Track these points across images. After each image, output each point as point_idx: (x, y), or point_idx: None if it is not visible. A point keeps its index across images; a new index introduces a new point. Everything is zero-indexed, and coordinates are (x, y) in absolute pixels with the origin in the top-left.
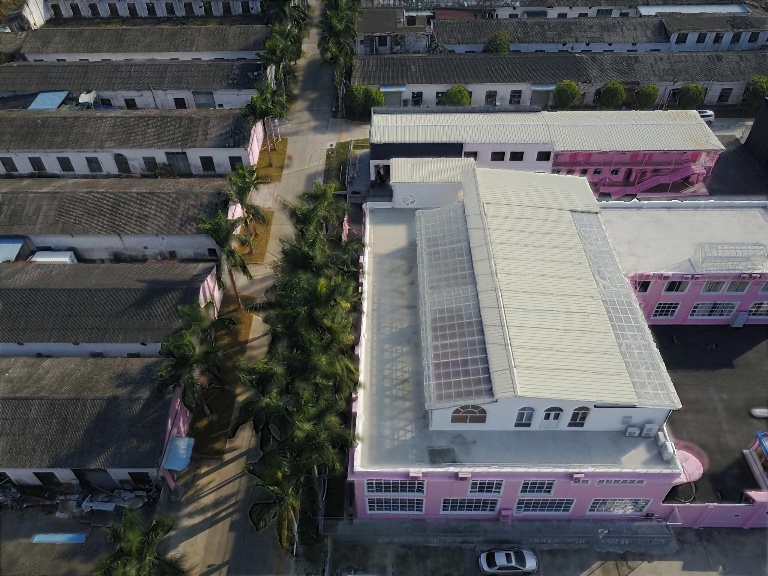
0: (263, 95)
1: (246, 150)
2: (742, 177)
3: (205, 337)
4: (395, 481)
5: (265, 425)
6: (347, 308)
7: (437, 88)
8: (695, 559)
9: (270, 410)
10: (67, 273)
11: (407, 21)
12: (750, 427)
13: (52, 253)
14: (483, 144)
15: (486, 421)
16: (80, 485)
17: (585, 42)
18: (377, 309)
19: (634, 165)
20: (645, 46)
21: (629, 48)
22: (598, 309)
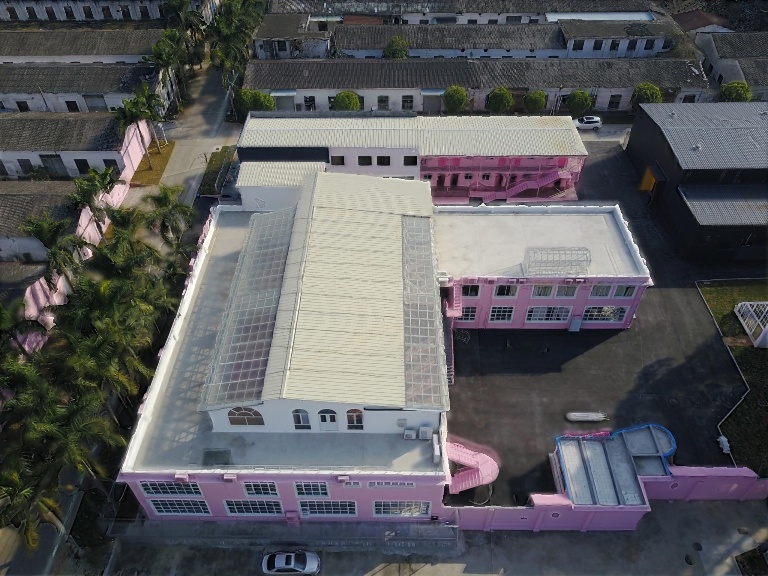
0: (135, 99)
1: (119, 153)
2: (615, 183)
3: (7, 339)
4: (169, 483)
5: (27, 426)
6: (148, 310)
7: (328, 93)
8: (478, 562)
9: (19, 411)
10: None
11: (319, 26)
12: (562, 430)
13: None
14: (348, 148)
15: (265, 423)
16: None
17: (483, 48)
18: (197, 312)
19: (502, 170)
20: (543, 52)
21: (527, 54)
22: (396, 312)
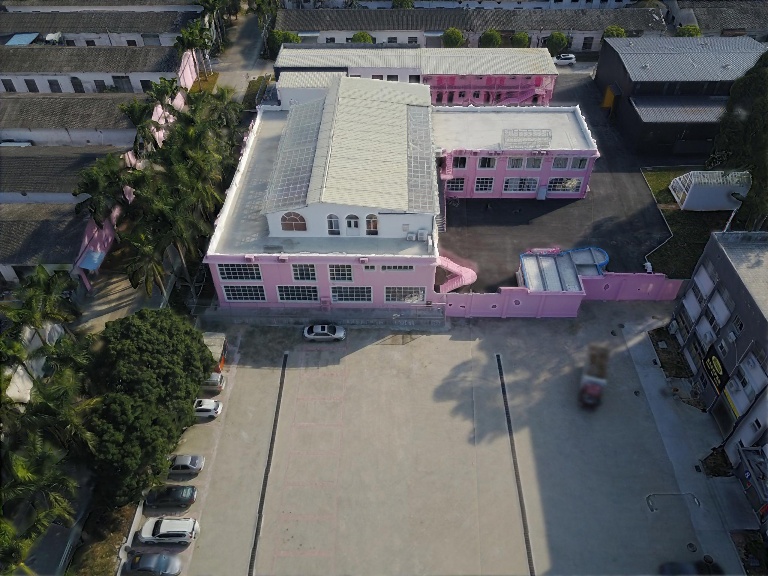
0: (191, 29)
1: (177, 75)
2: (583, 102)
3: (115, 179)
4: (239, 267)
5: (142, 219)
6: (219, 159)
7: (346, 34)
8: (460, 334)
9: (141, 200)
10: (22, 150)
11: None
12: None
13: (14, 143)
14: (364, 68)
15: (307, 228)
16: (20, 284)
17: (477, 0)
18: (251, 171)
19: (489, 88)
20: (529, 4)
21: (515, 6)
22: (402, 160)
